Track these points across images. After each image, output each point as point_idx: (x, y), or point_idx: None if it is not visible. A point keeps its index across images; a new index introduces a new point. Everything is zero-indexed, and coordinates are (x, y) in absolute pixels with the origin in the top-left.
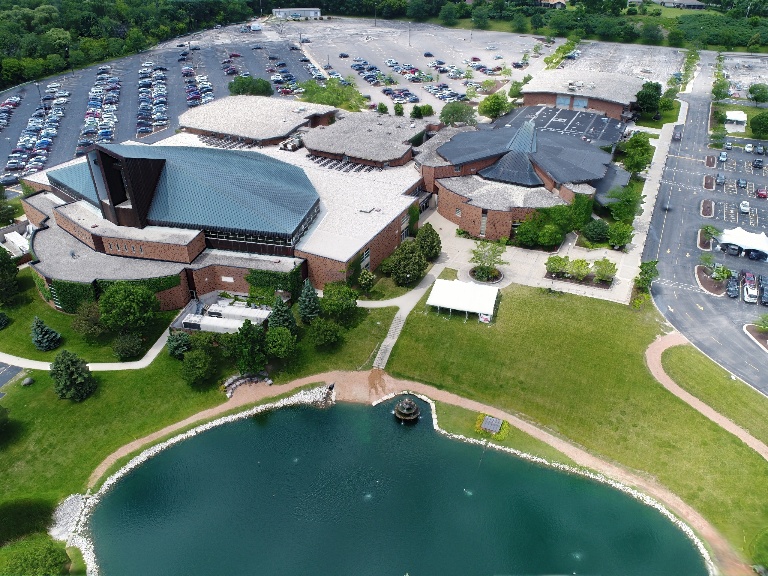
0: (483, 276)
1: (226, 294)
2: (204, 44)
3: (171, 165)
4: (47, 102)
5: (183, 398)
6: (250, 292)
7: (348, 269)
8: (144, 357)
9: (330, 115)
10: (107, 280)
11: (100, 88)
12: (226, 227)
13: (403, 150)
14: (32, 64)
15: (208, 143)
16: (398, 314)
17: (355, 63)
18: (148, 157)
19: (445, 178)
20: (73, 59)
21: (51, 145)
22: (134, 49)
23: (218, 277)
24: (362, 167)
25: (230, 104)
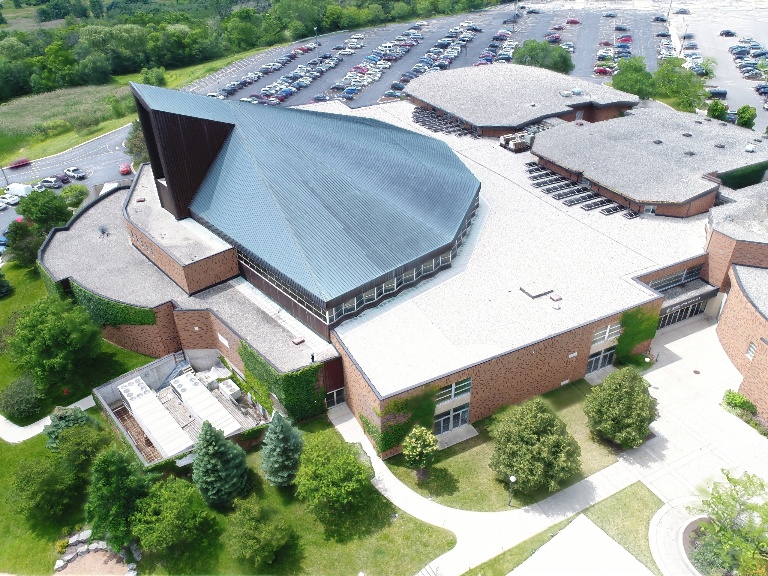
0: (715, 562)
1: (225, 361)
2: (549, 8)
3: (237, 135)
4: (335, 52)
5: (3, 530)
6: (245, 375)
7: (389, 412)
8: (33, 423)
9: (621, 108)
10: (76, 284)
11: (395, 43)
12: (255, 254)
13: (695, 189)
14: (352, 13)
15: (415, 119)
16: (439, 561)
17: (739, 45)
18: (202, 116)
19: (758, 268)
20: (395, 12)
21: (292, 95)
22: (469, 8)
23: (215, 331)
24: (601, 203)
25: (486, 72)
